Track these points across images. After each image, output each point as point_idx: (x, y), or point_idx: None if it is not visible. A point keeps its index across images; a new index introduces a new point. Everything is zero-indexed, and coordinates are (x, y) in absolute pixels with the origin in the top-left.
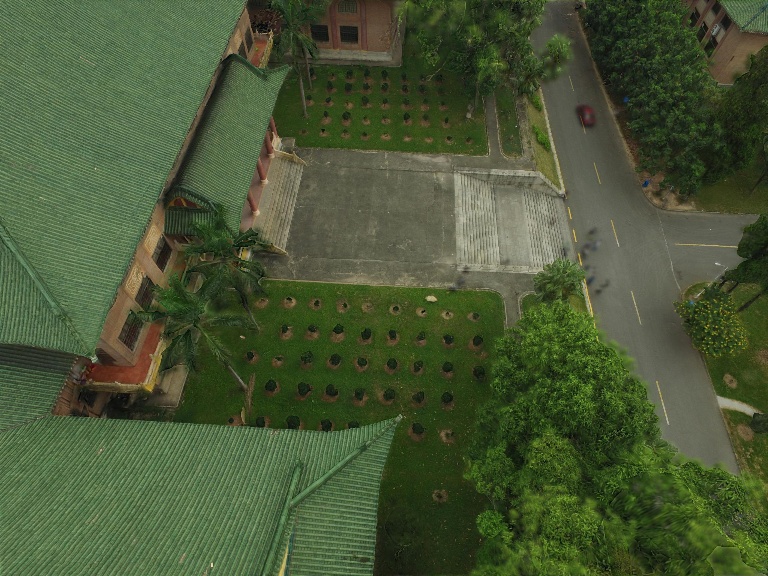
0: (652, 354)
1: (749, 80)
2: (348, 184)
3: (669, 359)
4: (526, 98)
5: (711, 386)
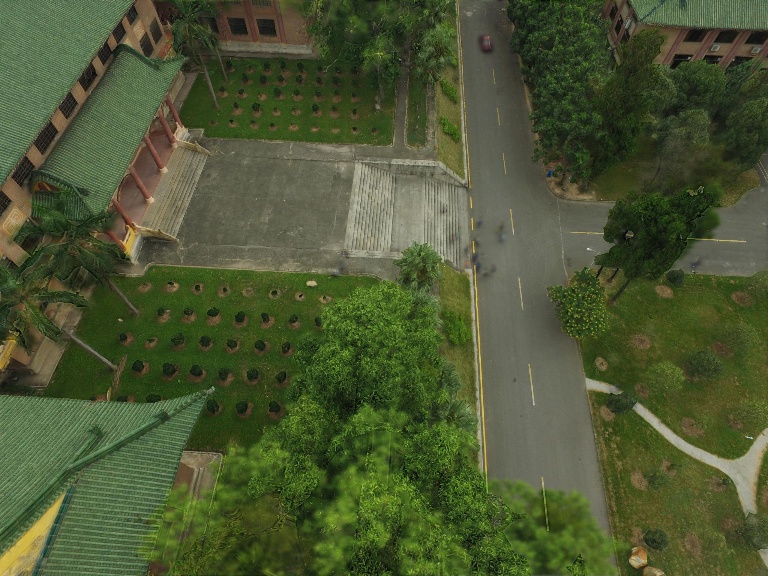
0: (529, 338)
1: (622, 69)
2: (249, 173)
3: (545, 343)
4: (440, 90)
5: (582, 369)
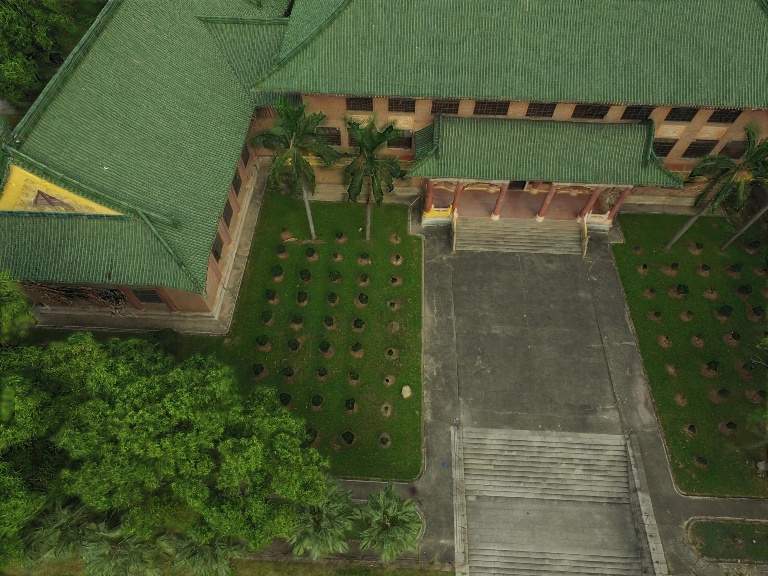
0: None
1: None
2: (565, 301)
3: None
4: None
5: None
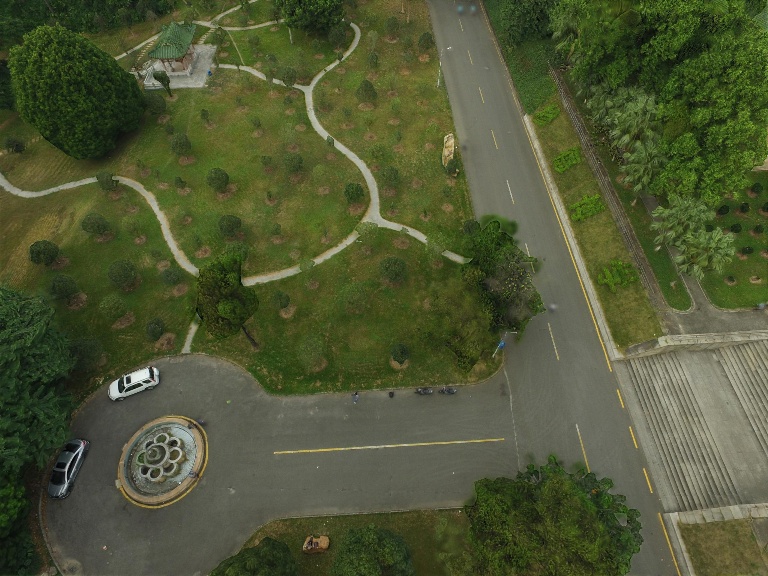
0: None
1: None
2: None
3: None
4: None
5: None
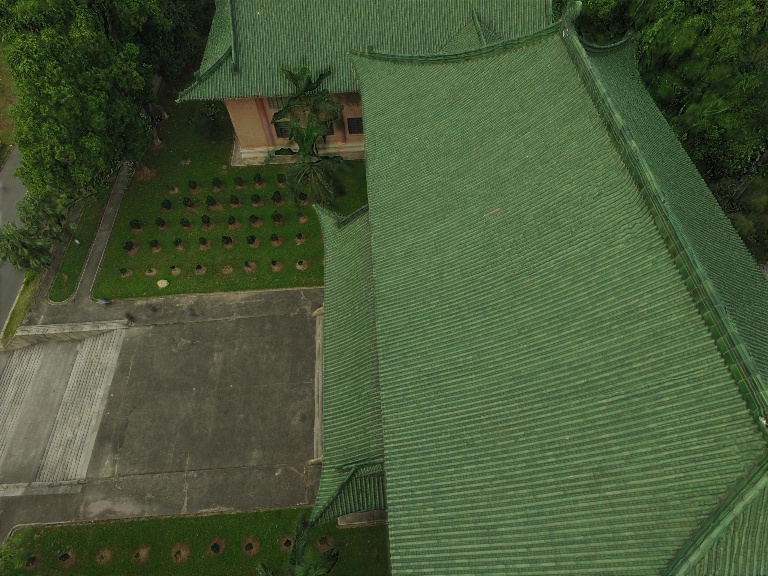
0: None
1: None
2: (247, 431)
3: None
4: None
5: None
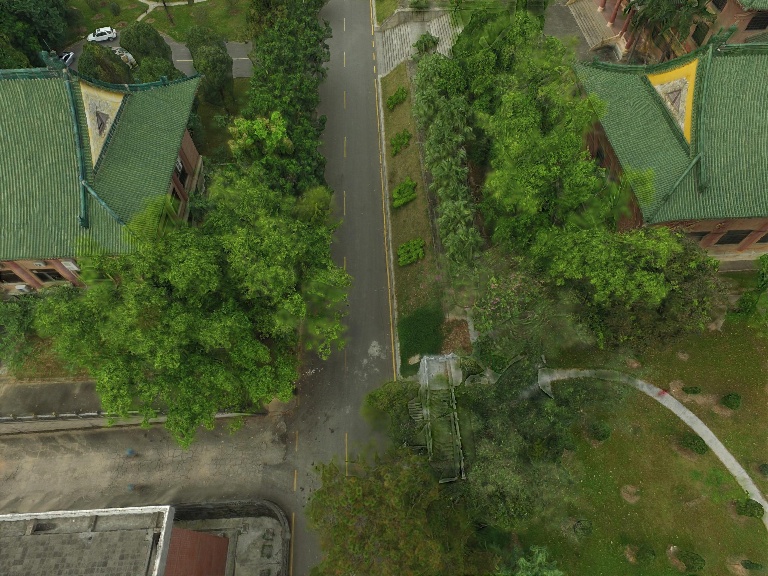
0: (343, 8)
1: None
2: None
3: (335, 7)
4: None
5: None
